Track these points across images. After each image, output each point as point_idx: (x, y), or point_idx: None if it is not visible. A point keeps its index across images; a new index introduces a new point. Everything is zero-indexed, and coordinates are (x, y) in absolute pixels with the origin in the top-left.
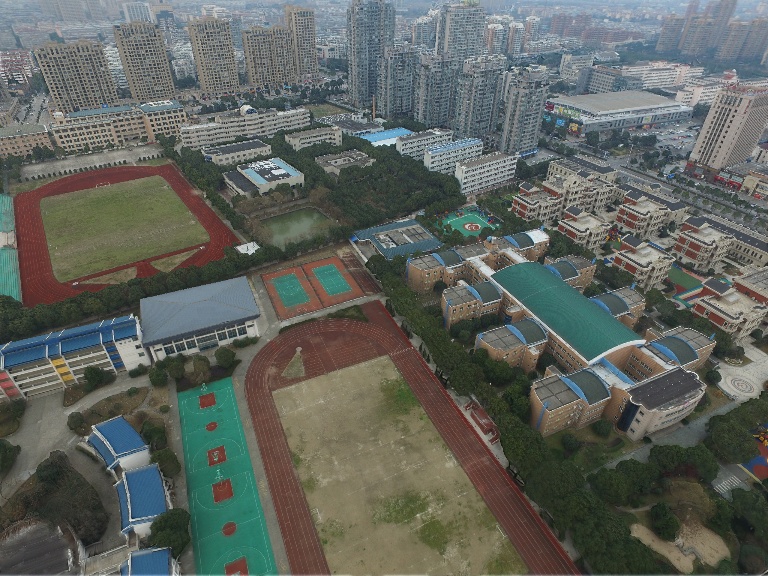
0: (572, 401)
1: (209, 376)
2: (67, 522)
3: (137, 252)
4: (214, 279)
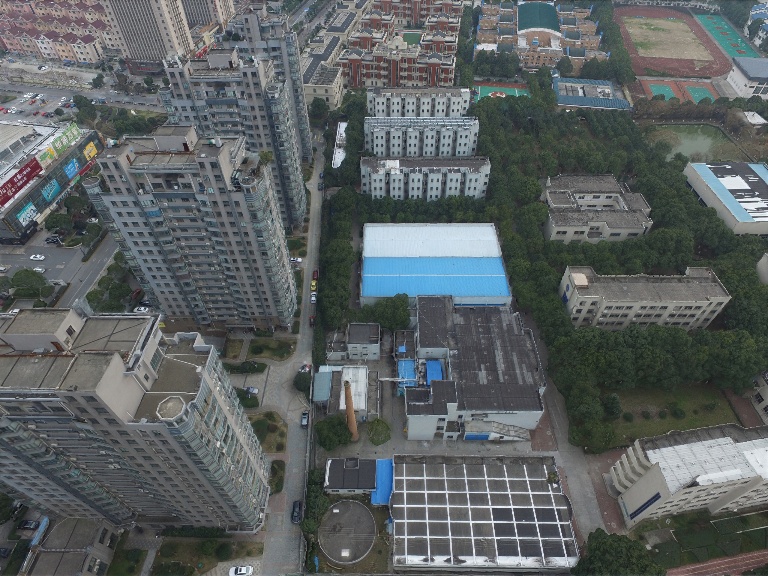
0: (577, 8)
1: None
2: None
3: None
4: None
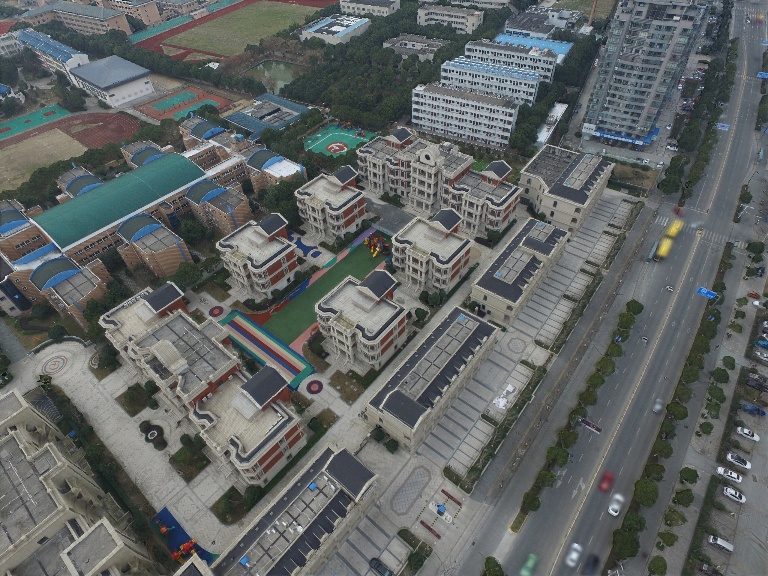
0: None
1: (68, 106)
2: None
3: (205, 45)
4: (163, 70)
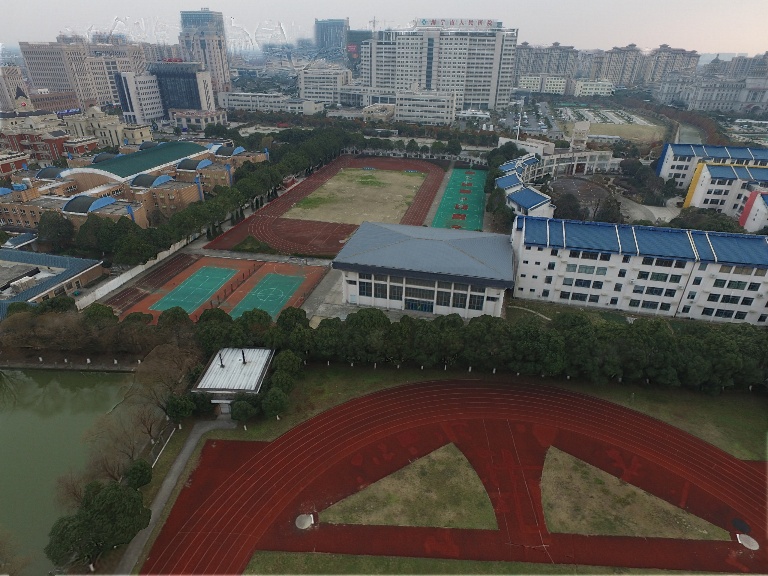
0: (249, 152)
1: None
2: (558, 196)
3: None
4: None
